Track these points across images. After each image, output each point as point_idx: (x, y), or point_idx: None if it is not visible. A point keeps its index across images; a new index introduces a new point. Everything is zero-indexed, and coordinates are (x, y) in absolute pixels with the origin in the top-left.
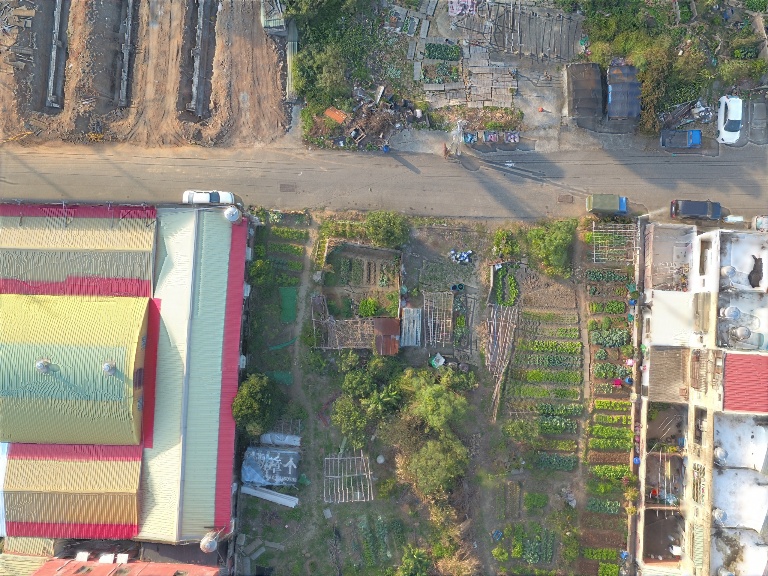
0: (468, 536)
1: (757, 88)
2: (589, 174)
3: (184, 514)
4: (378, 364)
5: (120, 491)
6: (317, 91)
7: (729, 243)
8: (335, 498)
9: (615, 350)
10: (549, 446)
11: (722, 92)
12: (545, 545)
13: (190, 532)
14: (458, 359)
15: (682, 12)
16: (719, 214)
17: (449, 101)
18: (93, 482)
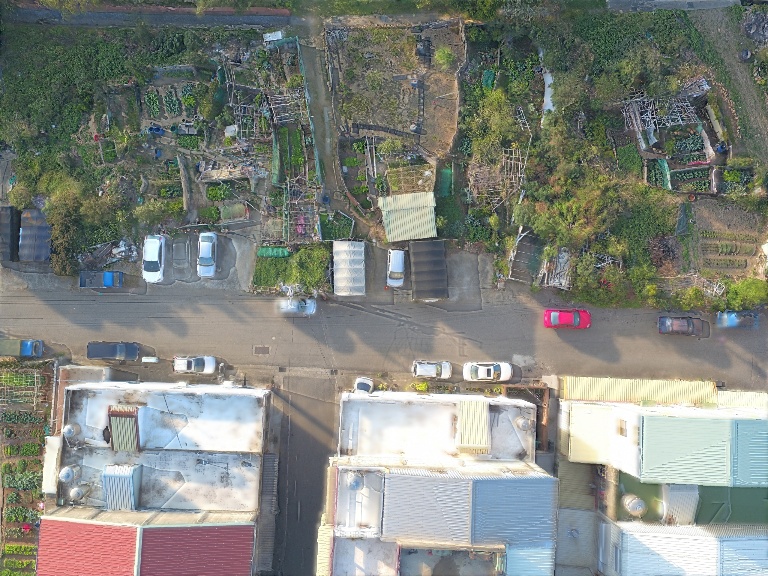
0: None
1: (182, 227)
2: (11, 315)
3: None
4: None
5: None
6: None
7: (85, 398)
8: None
9: (28, 493)
10: None
11: (149, 231)
12: None
13: None
14: None
15: (106, 152)
16: (136, 355)
17: None
18: None
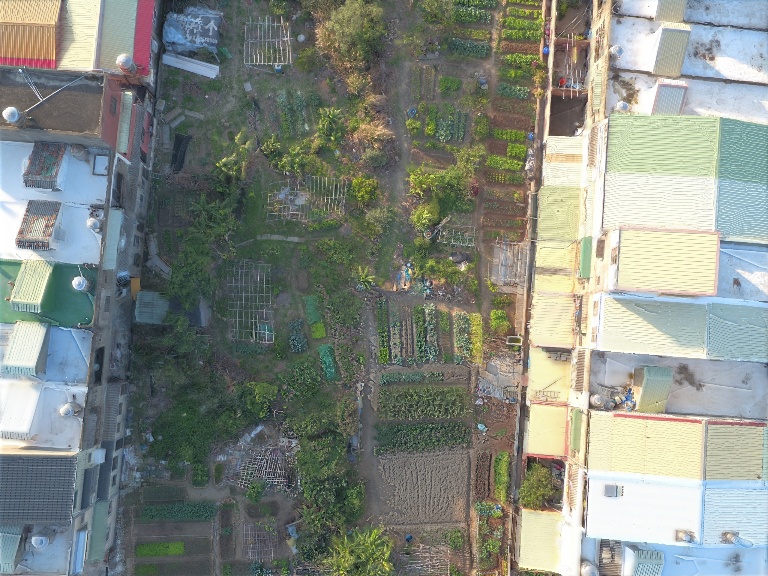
0: (383, 110)
1: None
2: None
3: (102, 47)
4: None
5: (39, 22)
6: None
7: None
8: (254, 60)
9: None
10: (464, 35)
11: None
12: (457, 125)
13: (108, 65)
14: None
15: None
16: None
17: None
18: (11, 6)
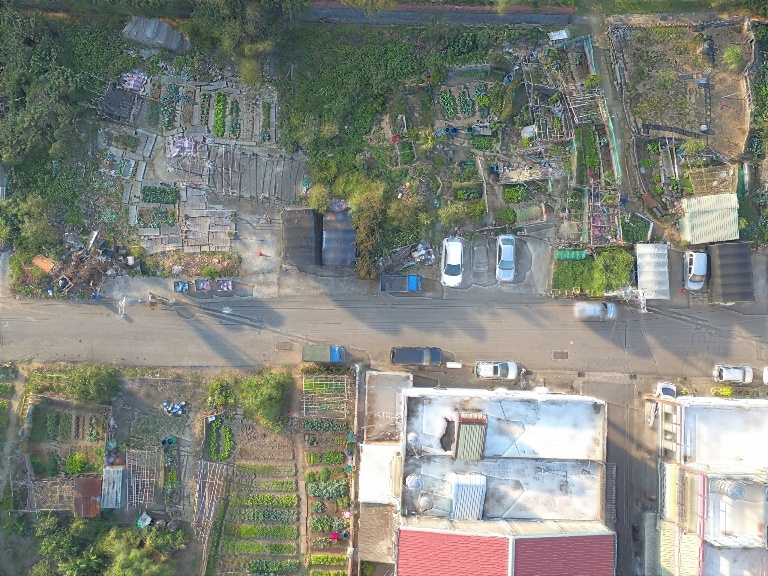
0: None
1: (480, 230)
2: (309, 320)
3: None
4: (79, 526)
5: None
6: (23, 239)
7: (421, 406)
8: None
9: (333, 502)
10: None
11: (446, 233)
12: None
13: None
14: (169, 516)
15: (403, 153)
16: (439, 360)
17: (165, 246)
18: None
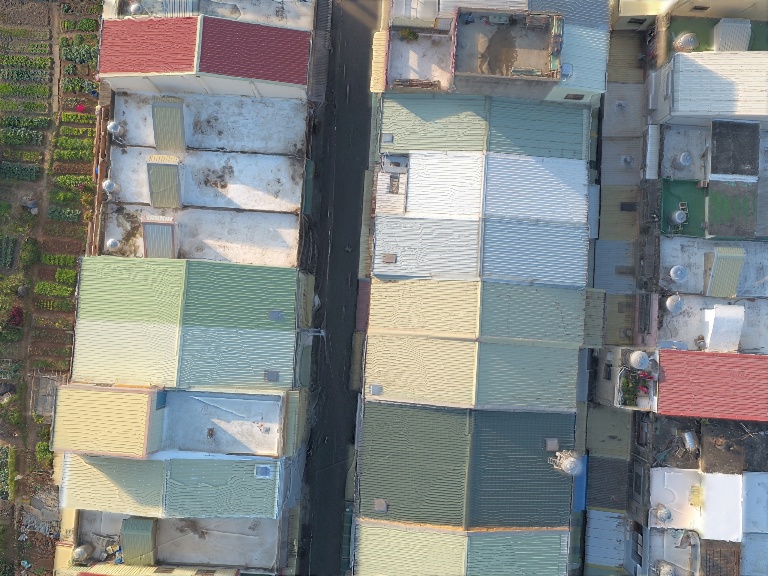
0: None
1: None
2: None
3: None
4: None
5: None
6: None
7: None
8: None
9: (84, 66)
10: (15, 157)
11: None
12: (5, 251)
13: None
14: None
15: None
16: None
17: None
18: None
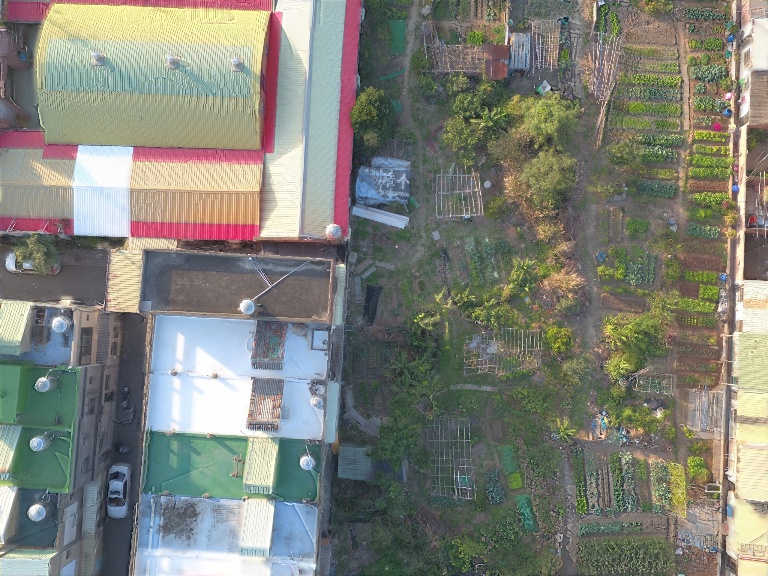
0: (574, 255)
1: None
2: None
3: (306, 212)
4: (487, 88)
5: (244, 190)
6: None
7: None
8: (447, 212)
9: (714, 84)
10: (650, 174)
11: None
12: (647, 267)
13: (312, 230)
14: None
15: None
16: None
17: None
18: (219, 177)
